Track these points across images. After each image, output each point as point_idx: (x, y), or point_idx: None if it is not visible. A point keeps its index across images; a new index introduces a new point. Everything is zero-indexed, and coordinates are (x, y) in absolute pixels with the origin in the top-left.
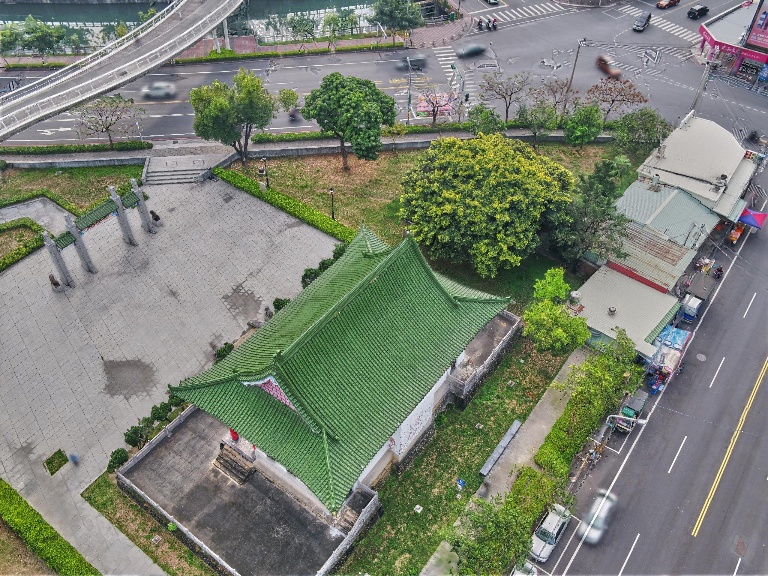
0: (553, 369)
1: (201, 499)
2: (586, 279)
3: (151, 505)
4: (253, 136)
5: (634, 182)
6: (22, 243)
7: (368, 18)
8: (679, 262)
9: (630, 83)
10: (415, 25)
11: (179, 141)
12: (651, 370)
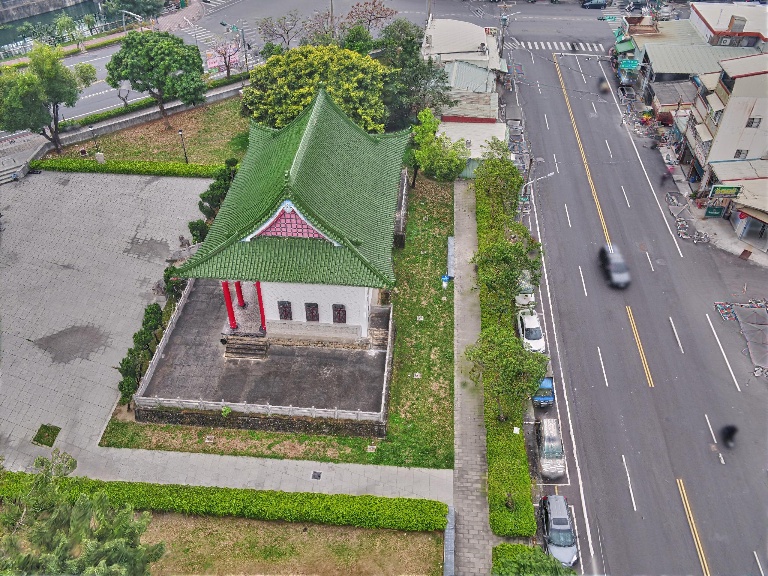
0: (449, 200)
1: (235, 384)
2: None
3: (190, 409)
4: None
5: None
6: None
7: (111, 8)
8: (491, 102)
9: (378, 2)
10: (159, 8)
11: None
12: None
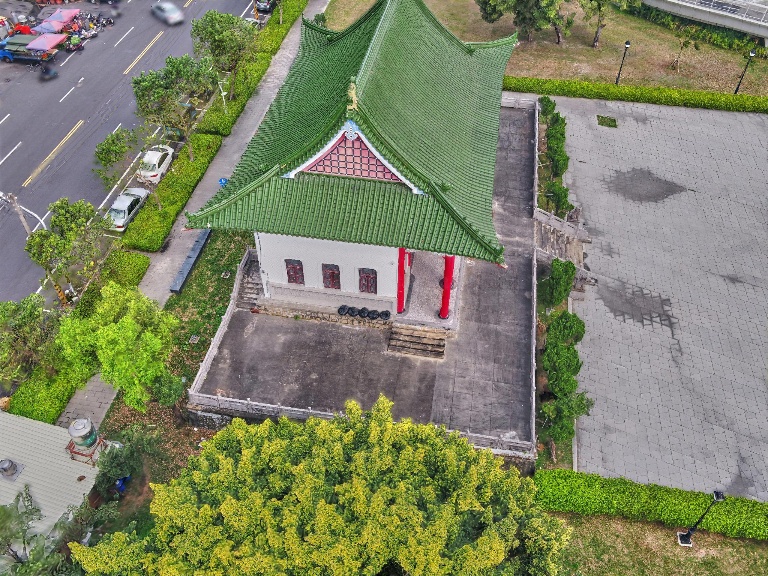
0: None
1: None
2: None
3: None
4: None
5: None
6: None
7: None
8: None
9: None
10: None
11: None
12: None
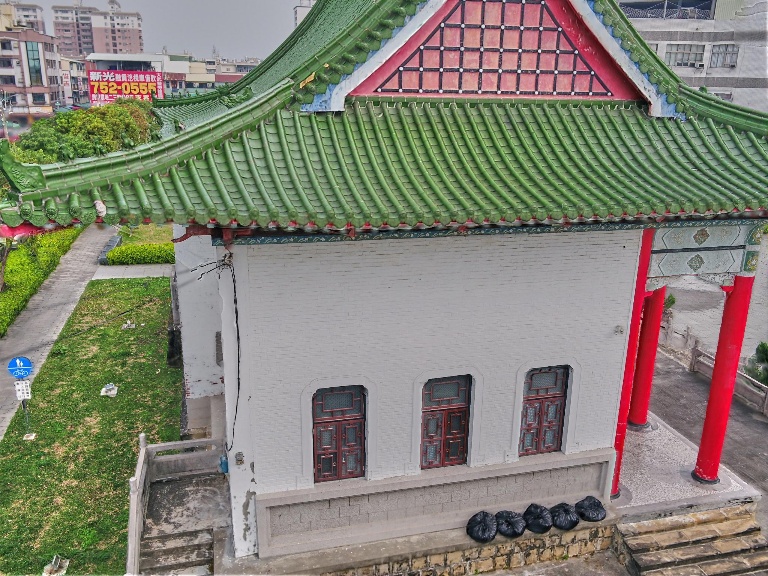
0: None
1: None
2: None
3: None
4: None
5: None
6: None
7: None
8: None
9: None
10: None
11: None
12: None
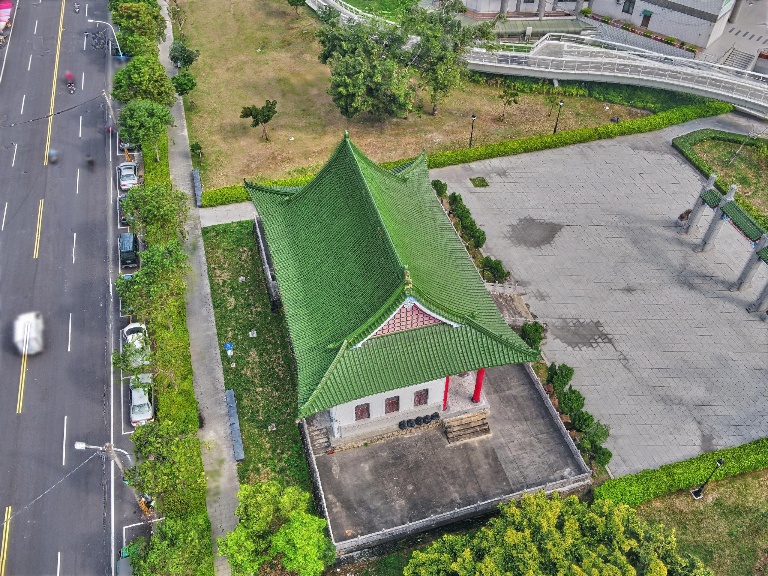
0: None
1: None
2: None
3: None
4: None
5: None
6: None
7: None
8: None
9: None
10: None
11: None
12: None
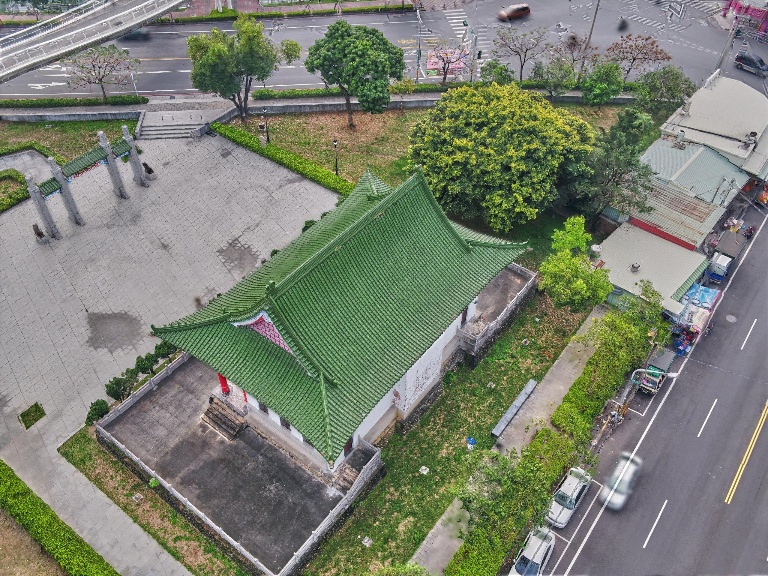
0: (571, 328)
1: (187, 455)
2: (606, 238)
3: (132, 460)
4: (254, 92)
5: (657, 140)
6: (7, 194)
7: None
8: (707, 219)
9: (652, 40)
10: None
11: (176, 97)
12: (677, 330)
